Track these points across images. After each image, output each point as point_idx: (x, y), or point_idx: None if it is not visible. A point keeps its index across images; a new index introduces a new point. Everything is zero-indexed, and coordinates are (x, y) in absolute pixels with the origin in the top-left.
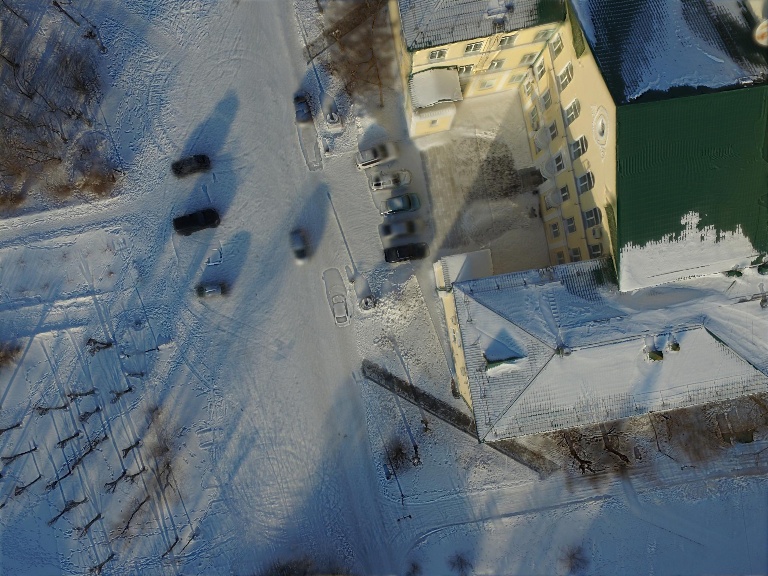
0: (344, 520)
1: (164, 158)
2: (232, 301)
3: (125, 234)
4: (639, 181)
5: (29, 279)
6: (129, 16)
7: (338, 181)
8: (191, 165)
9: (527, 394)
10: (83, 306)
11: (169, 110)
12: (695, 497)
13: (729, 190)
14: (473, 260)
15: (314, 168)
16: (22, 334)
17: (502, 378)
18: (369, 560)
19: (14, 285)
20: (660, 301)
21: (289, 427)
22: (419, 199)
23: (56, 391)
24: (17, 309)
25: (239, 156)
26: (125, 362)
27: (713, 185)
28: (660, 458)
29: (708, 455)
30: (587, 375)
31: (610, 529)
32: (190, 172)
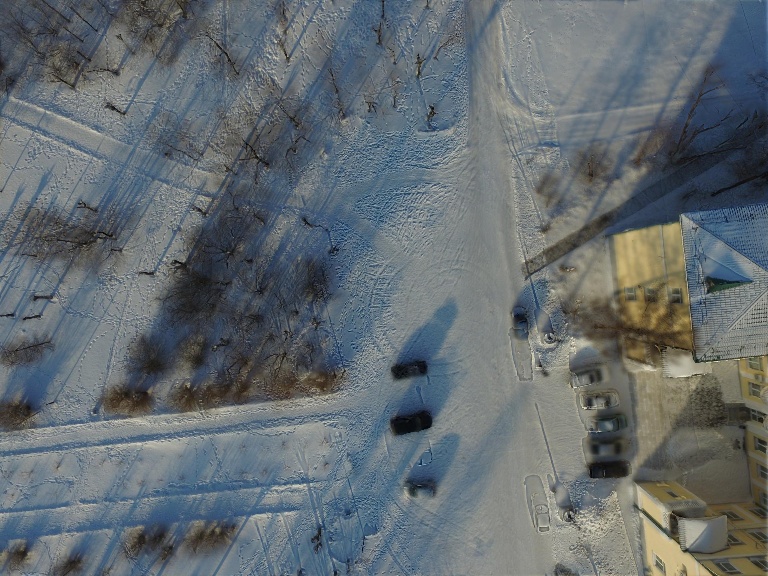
0: None
1: (382, 358)
2: (437, 498)
3: (342, 428)
4: None
5: (249, 463)
6: (359, 221)
7: (546, 393)
8: (415, 375)
9: None
10: (297, 492)
11: (390, 313)
12: None
13: None
14: (713, 529)
15: (524, 379)
16: (239, 513)
17: None
18: None
19: (234, 467)
20: None
21: None
22: (626, 420)
23: (266, 568)
24: (235, 489)
25: (453, 361)
26: (333, 547)
27: None
28: None
29: None
30: None
31: None
32: None
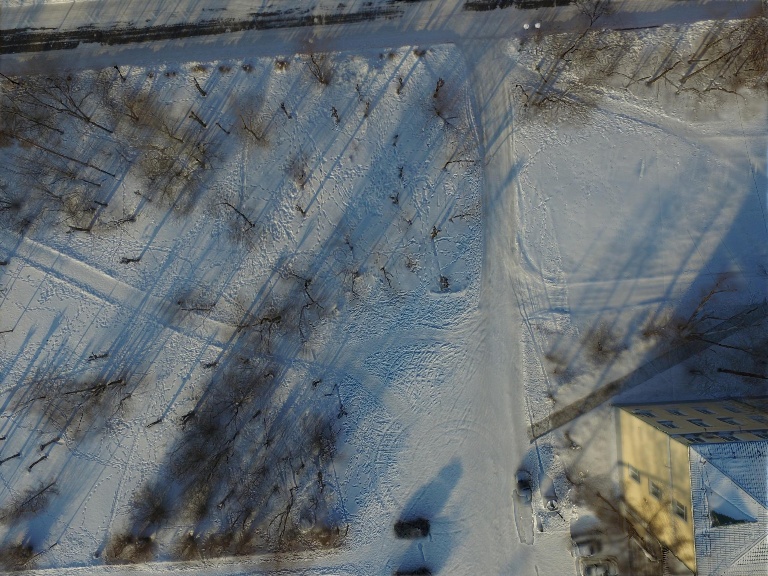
0: None
1: (385, 514)
2: None
3: None
4: None
5: None
6: (368, 377)
7: (547, 556)
8: (417, 538)
9: None
10: None
11: (395, 469)
12: None
13: None
14: None
15: (525, 541)
16: None
17: None
18: None
19: None
20: None
21: None
22: None
23: None
24: None
25: (456, 520)
26: None
27: None
28: None
29: None
30: None
31: None
32: None
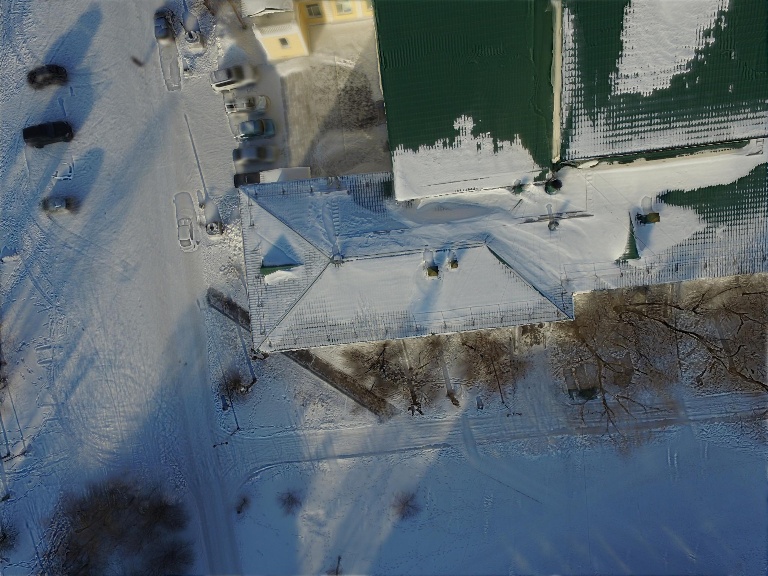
0: (179, 449)
1: (22, 68)
2: (81, 218)
3: None
4: (403, 76)
5: None
6: None
7: (196, 103)
8: (43, 74)
9: (302, 304)
10: None
11: (31, 19)
12: (535, 452)
13: (493, 90)
14: (288, 176)
15: (173, 88)
16: None
17: (279, 286)
18: (201, 492)
19: None
20: (444, 216)
21: (129, 350)
22: (274, 126)
23: None
24: None
25: (98, 71)
26: None
27: (472, 81)
28: (503, 410)
29: (553, 411)
30: (364, 288)
31: (447, 479)
32: (44, 83)
